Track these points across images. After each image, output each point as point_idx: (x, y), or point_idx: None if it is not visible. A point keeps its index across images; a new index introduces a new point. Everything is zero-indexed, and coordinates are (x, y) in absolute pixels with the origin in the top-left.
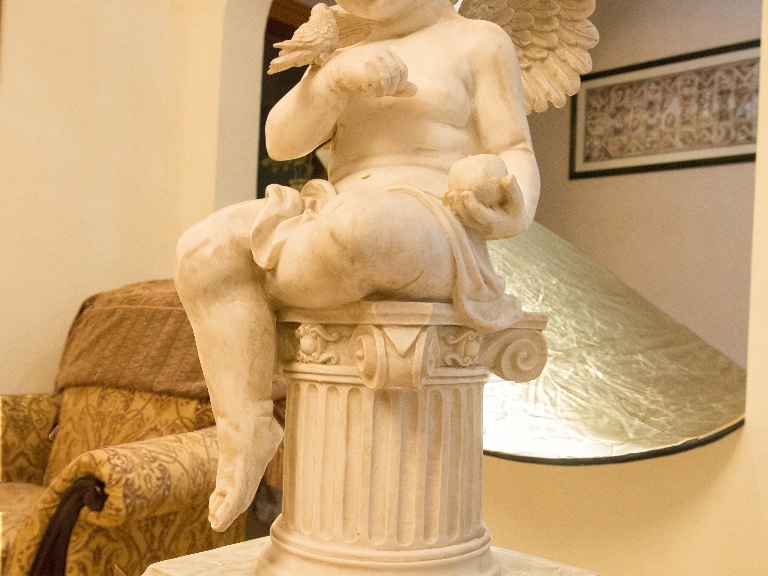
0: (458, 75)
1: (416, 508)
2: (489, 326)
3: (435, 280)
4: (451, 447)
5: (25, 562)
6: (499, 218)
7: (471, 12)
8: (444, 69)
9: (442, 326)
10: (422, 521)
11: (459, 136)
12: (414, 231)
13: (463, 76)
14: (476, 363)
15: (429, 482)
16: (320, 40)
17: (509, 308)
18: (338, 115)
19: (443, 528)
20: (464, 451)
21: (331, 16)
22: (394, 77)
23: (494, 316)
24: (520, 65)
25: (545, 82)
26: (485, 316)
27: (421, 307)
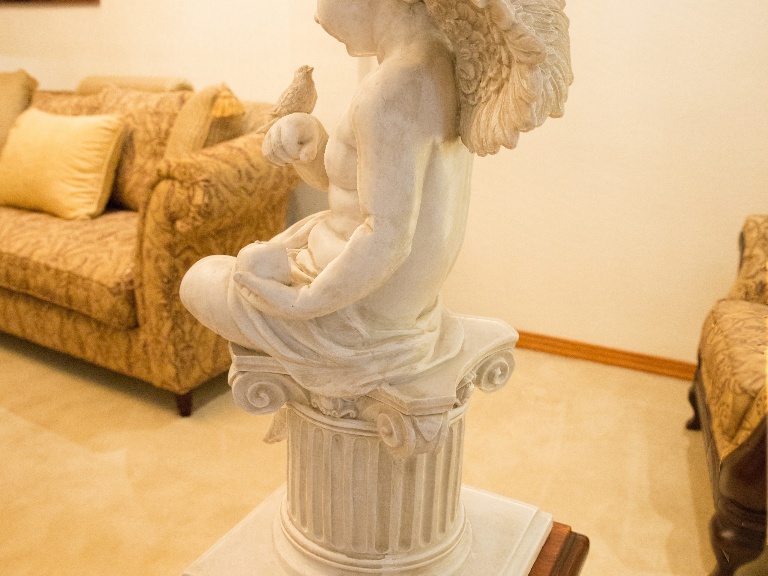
0: (340, 138)
1: (296, 499)
2: (309, 390)
3: (234, 340)
4: (318, 472)
5: (762, 409)
6: (257, 304)
7: (442, 29)
8: (333, 132)
9: (284, 374)
10: (299, 511)
11: (345, 200)
12: (201, 301)
13: (344, 139)
14: (350, 416)
15: (304, 487)
16: (279, 109)
17: (348, 380)
18: (310, 167)
19: (310, 527)
20: (326, 481)
21: (300, 79)
22: (275, 152)
23: (318, 383)
24: (490, 89)
25: (495, 116)
26: (306, 380)
27: (232, 356)
